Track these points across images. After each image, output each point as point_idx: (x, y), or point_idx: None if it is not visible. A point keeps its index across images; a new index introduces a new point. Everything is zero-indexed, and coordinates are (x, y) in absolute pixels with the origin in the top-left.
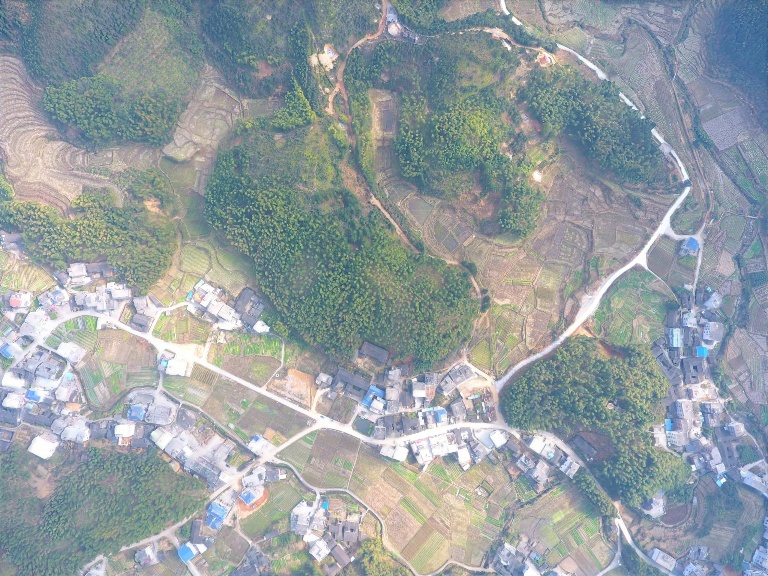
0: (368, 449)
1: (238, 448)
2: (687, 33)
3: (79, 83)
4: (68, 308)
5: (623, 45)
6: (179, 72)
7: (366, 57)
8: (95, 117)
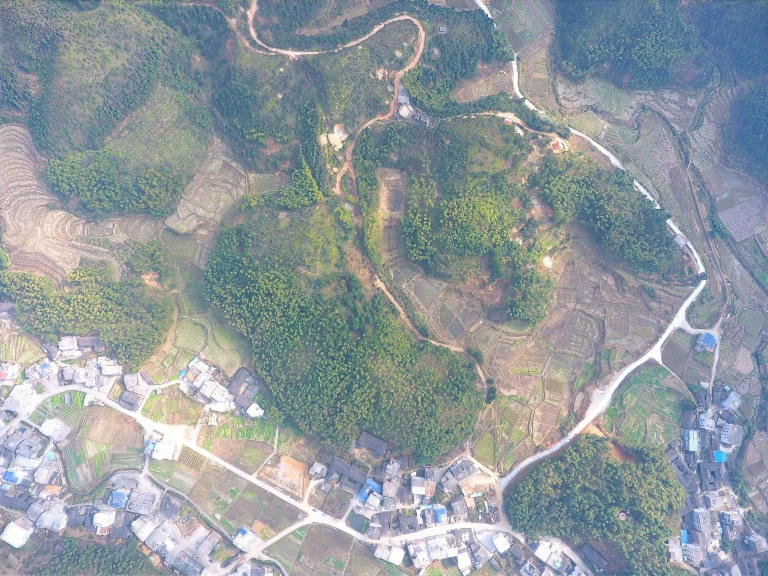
0: (362, 548)
1: (223, 541)
2: (702, 121)
3: (84, 156)
4: (56, 382)
5: (637, 131)
6: (187, 145)
7: (376, 137)
8: (98, 189)
